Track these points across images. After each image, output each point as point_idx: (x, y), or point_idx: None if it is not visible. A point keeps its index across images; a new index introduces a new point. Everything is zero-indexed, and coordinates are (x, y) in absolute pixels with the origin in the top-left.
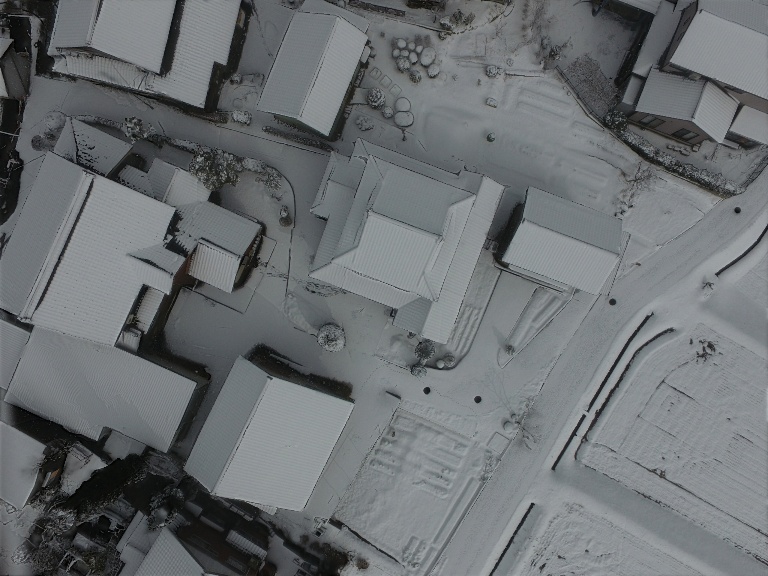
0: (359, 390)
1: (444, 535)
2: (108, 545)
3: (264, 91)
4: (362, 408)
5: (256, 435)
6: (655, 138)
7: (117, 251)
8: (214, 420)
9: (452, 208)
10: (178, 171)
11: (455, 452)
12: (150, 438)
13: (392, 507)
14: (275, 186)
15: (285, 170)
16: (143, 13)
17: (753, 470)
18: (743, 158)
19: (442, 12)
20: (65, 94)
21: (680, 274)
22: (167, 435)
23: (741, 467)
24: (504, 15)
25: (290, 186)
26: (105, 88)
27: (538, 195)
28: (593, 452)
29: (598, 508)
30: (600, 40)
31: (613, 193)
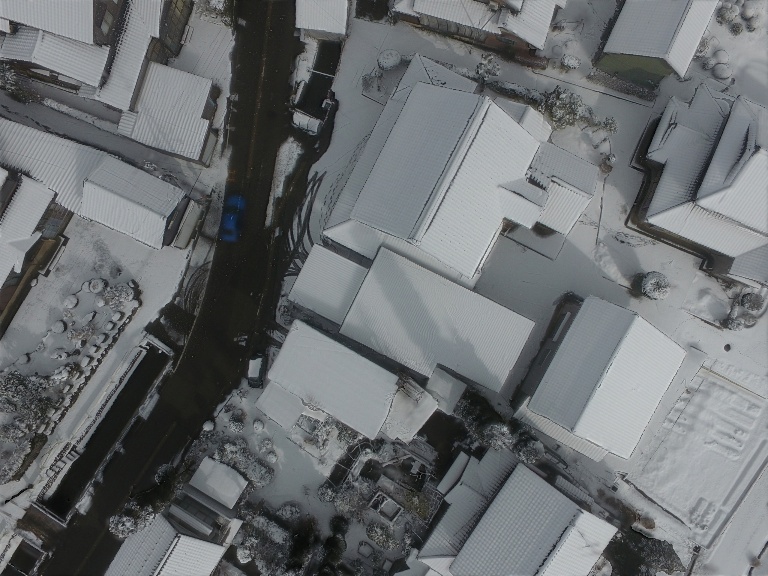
0: None
1: (735, 498)
2: (426, 486)
3: (613, 33)
4: None
5: (614, 374)
6: None
7: (492, 181)
8: (564, 359)
9: None
10: (530, 109)
11: (748, 413)
12: (484, 377)
13: (681, 466)
14: (614, 129)
15: (600, 118)
16: None
17: None
18: None
19: None
20: (384, 37)
21: None
22: (502, 374)
23: None
24: None
25: None
26: (423, 32)
27: None
28: None
29: None
30: None
31: None
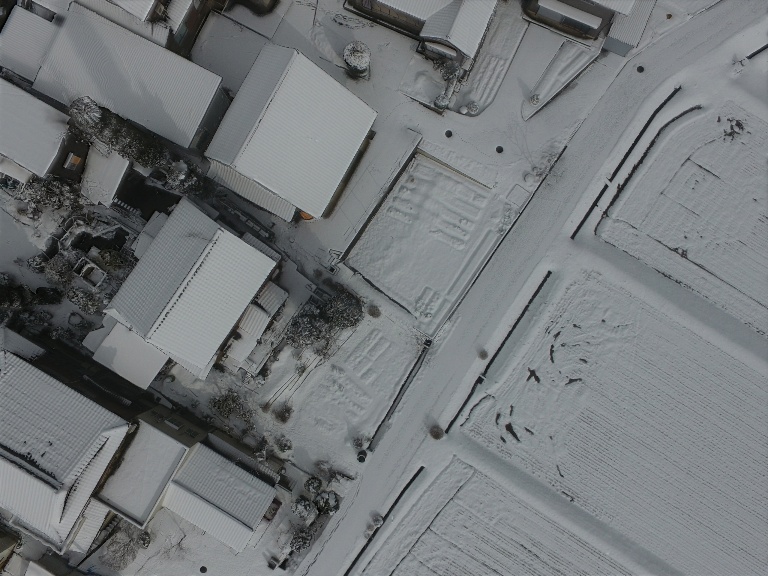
0: (381, 123)
1: (459, 286)
2: (123, 247)
3: None
4: (383, 141)
5: (279, 114)
6: None
7: None
8: (238, 104)
9: None
10: None
11: (474, 203)
12: (172, 132)
13: (407, 255)
14: None
15: None
16: None
17: None
18: None
19: None
20: None
21: (710, 46)
22: (189, 129)
23: (766, 250)
24: None
25: None
26: None
27: None
28: (613, 227)
29: (617, 275)
30: None
31: None
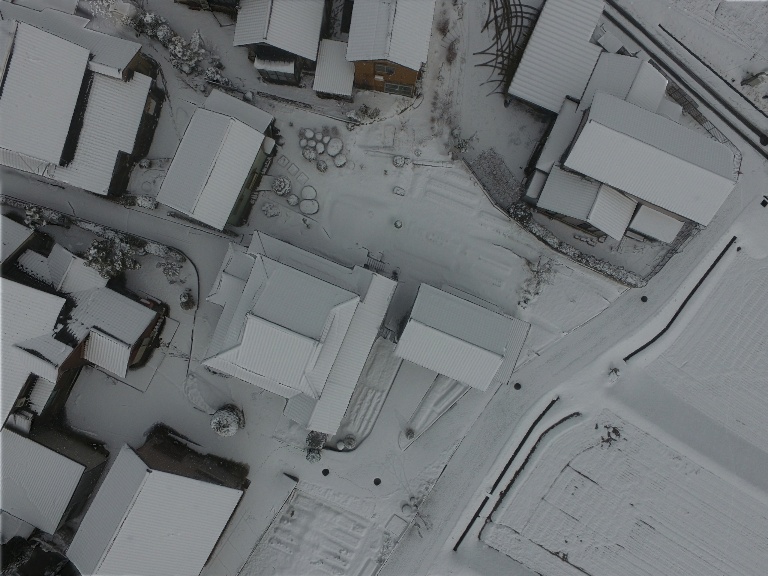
0: (256, 471)
1: None
2: None
3: (163, 183)
4: (258, 489)
5: (135, 526)
6: (563, 227)
7: (3, 342)
8: (97, 507)
9: (334, 310)
10: (74, 259)
11: (354, 533)
12: (37, 520)
13: None
14: (173, 274)
15: (191, 253)
16: (42, 109)
17: (655, 556)
18: (648, 250)
19: (347, 106)
20: None
21: (585, 361)
22: (54, 517)
23: (643, 553)
24: (413, 107)
25: (195, 269)
26: None
27: (429, 292)
28: (497, 533)
29: None
30: (511, 130)
31: (517, 282)
